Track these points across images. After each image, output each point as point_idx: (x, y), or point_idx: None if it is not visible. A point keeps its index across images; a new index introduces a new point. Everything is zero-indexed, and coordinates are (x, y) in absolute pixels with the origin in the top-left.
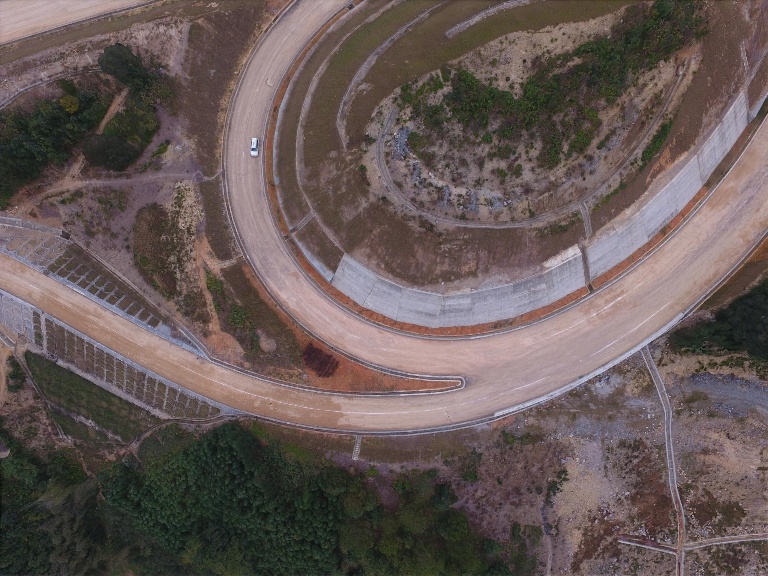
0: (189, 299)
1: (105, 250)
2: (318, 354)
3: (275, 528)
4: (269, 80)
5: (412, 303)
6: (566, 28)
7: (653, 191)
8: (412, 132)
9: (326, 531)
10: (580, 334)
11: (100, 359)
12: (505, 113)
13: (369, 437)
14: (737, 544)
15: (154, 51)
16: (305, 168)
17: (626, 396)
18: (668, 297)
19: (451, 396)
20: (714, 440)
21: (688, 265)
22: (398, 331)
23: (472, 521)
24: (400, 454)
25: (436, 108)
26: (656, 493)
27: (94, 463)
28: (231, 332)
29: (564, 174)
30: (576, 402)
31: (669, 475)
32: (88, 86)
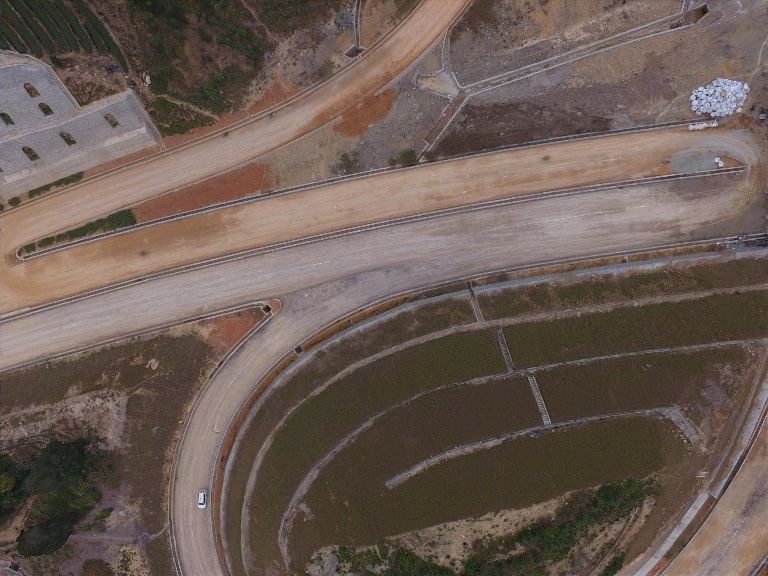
0: None
1: None
2: None
3: None
4: (215, 426)
5: None
6: (507, 515)
7: None
8: None
9: None
10: None
11: None
12: None
13: None
14: None
15: (91, 425)
16: (251, 552)
17: None
18: None
19: None
20: None
21: None
22: None
23: None
24: None
25: None
26: None
27: None
28: None
29: None
30: None
31: None
32: (24, 461)
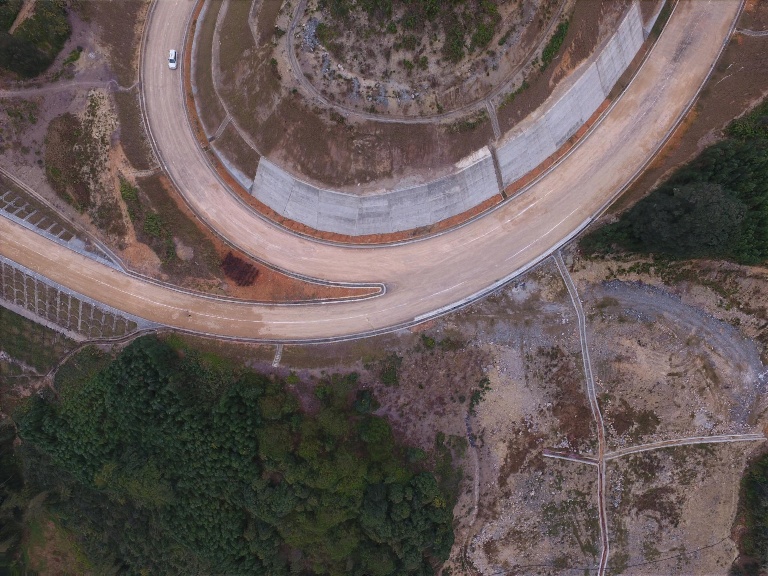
0: (103, 210)
1: (16, 166)
2: (238, 263)
3: (192, 436)
4: None
5: (330, 207)
6: None
7: (556, 95)
8: (320, 23)
9: (244, 437)
10: (495, 240)
11: (9, 277)
12: (407, 0)
13: (290, 345)
14: (653, 451)
15: None
16: (221, 73)
17: (541, 301)
18: (576, 203)
19: (372, 303)
20: (627, 347)
21: (594, 173)
22: (319, 240)
23: (396, 430)
24: (321, 360)
25: None
26: (576, 404)
27: (8, 402)
28: (147, 241)
29: (469, 69)
30: (494, 308)
31: (587, 385)
32: None
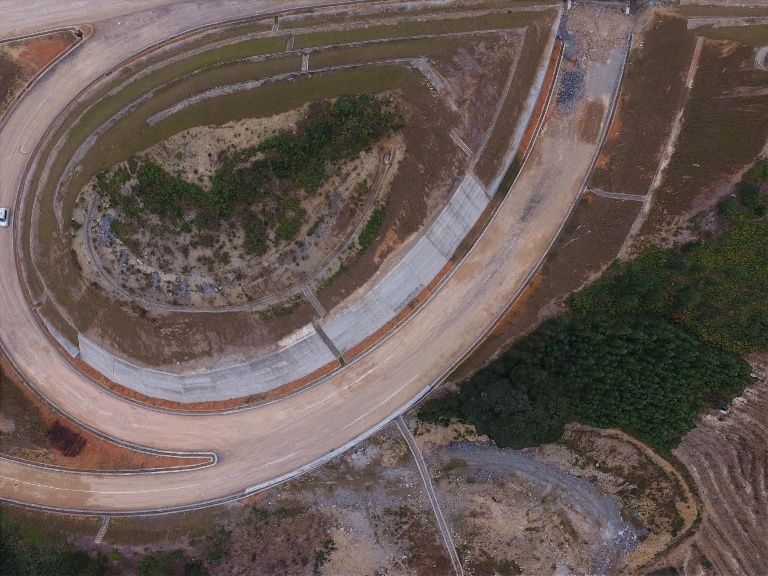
0: None
1: None
2: (64, 433)
3: None
4: (22, 147)
5: (154, 381)
6: (249, 124)
7: (384, 270)
8: (114, 219)
9: None
10: (332, 407)
11: None
12: (194, 205)
13: (117, 517)
14: None
15: None
16: (39, 244)
17: (383, 466)
18: (416, 370)
19: (203, 472)
20: (481, 503)
21: (436, 338)
22: (150, 407)
23: None
24: (147, 535)
25: (128, 198)
26: (434, 555)
27: None
28: None
29: (277, 260)
30: (333, 474)
31: (444, 538)
32: None
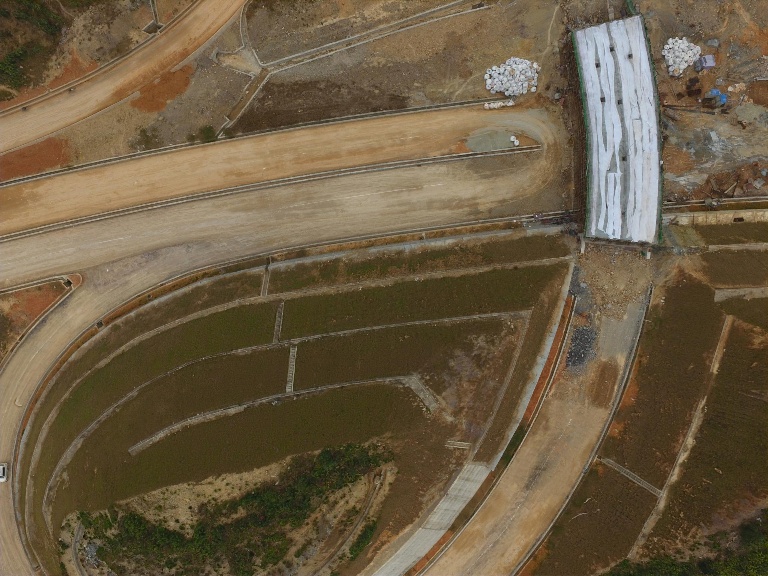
0: None
1: None
2: None
3: None
4: (17, 400)
5: None
6: (229, 479)
7: (378, 562)
8: (100, 547)
9: None
10: None
11: None
12: None
13: None
14: None
15: None
16: (34, 523)
17: None
18: None
19: None
20: None
21: None
22: None
23: None
24: None
25: (111, 541)
26: None
27: None
28: None
29: None
30: None
31: None
32: None
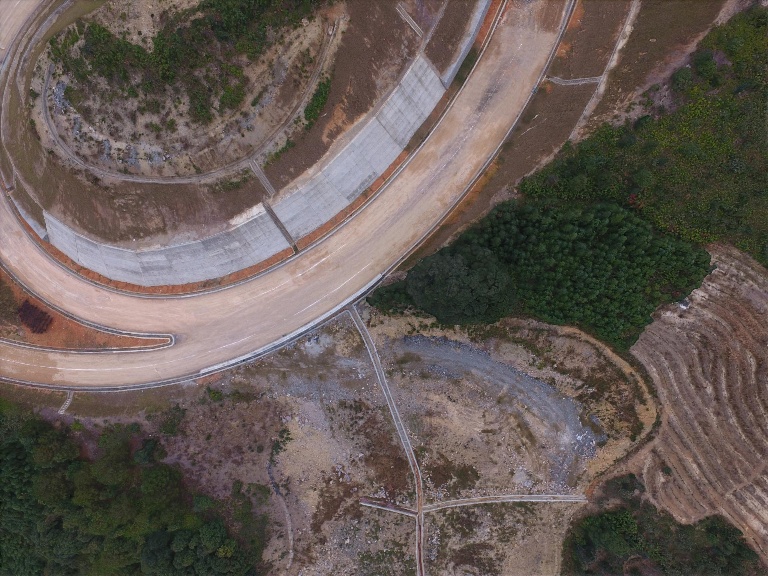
0: None
1: None
2: (33, 311)
3: None
4: (1, 43)
5: (114, 260)
6: None
7: (334, 151)
8: (68, 86)
9: (22, 482)
10: (285, 294)
11: None
12: (138, 66)
13: (81, 393)
14: (471, 506)
15: None
16: (9, 126)
17: (336, 356)
18: (369, 258)
19: (162, 353)
20: (436, 402)
21: (389, 227)
22: (114, 289)
23: (188, 477)
24: (107, 409)
25: (77, 61)
26: (391, 455)
27: None
28: None
29: (223, 130)
30: (286, 361)
31: (401, 437)
32: None
